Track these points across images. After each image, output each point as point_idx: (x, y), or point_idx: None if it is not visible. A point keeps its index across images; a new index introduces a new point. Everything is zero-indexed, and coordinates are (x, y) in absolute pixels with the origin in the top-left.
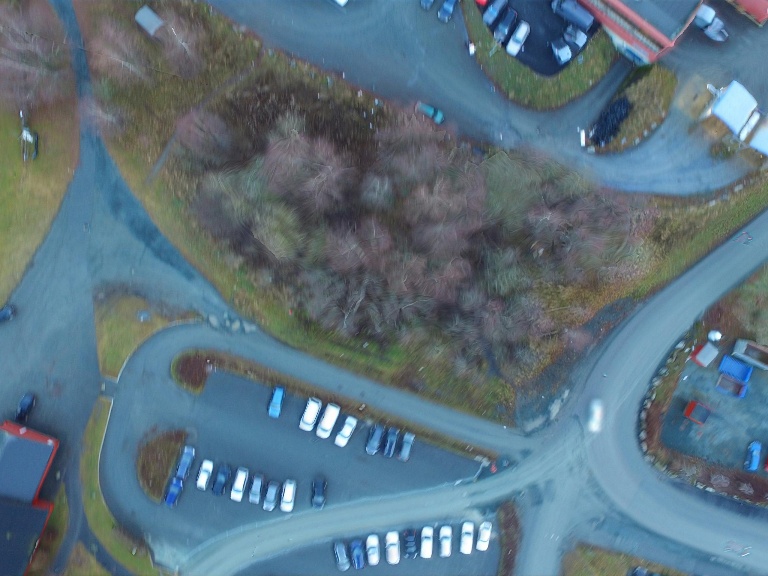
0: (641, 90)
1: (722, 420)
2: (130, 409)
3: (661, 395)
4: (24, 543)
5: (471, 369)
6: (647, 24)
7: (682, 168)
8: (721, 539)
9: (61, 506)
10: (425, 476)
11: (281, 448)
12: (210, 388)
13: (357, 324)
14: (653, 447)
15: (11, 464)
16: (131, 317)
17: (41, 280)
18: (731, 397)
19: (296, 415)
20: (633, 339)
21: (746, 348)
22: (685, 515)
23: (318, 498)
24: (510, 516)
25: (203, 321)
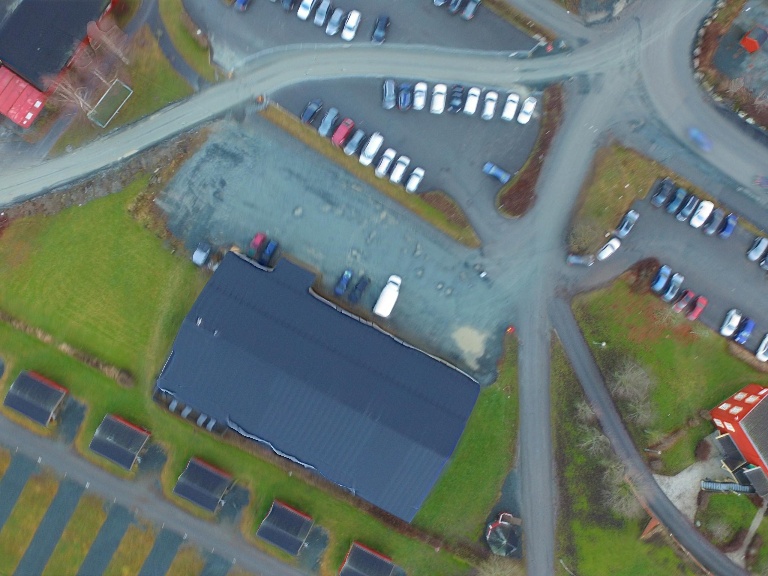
0: None
1: None
2: None
3: (722, 17)
4: None
5: None
6: None
7: None
8: (751, 170)
9: None
10: (483, 41)
11: None
12: None
13: None
14: (705, 65)
15: None
16: None
17: None
18: None
19: None
20: None
21: None
22: (721, 140)
23: (379, 32)
24: (555, 98)
25: None
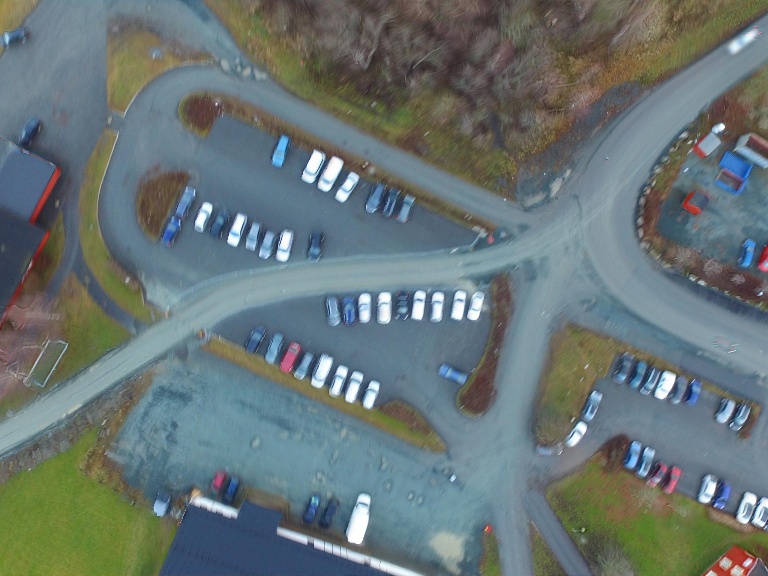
0: None
1: (719, 216)
2: (134, 145)
3: (661, 183)
4: (18, 260)
5: (476, 137)
6: None
7: None
8: (709, 333)
9: (57, 235)
10: (422, 241)
11: (281, 199)
12: (216, 132)
13: (367, 82)
14: (649, 234)
15: (12, 176)
16: (143, 53)
17: (57, 7)
18: (729, 193)
19: (299, 167)
20: (638, 125)
21: (748, 140)
22: (676, 306)
23: (314, 250)
24: (503, 289)
25: (214, 64)
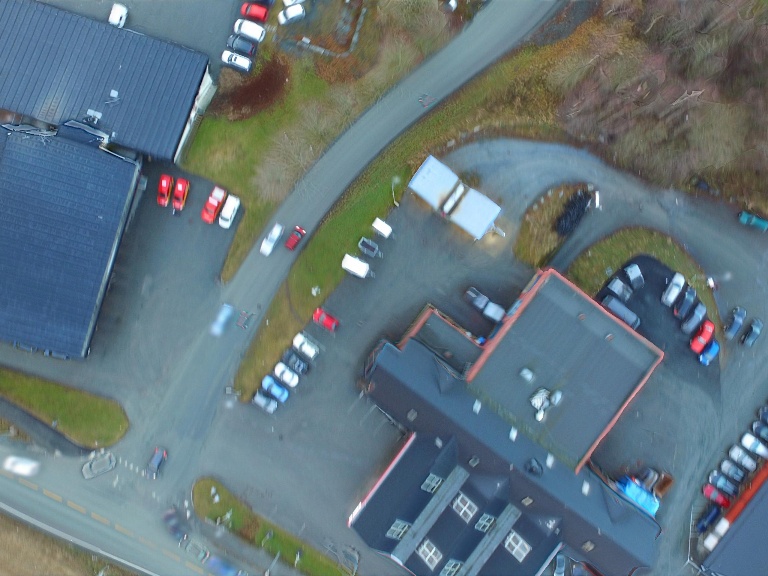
0: (547, 243)
1: None
2: None
3: None
4: None
5: None
6: (577, 290)
7: (507, 165)
8: None
9: None
10: None
11: None
12: None
13: None
14: None
15: None
16: None
17: None
18: None
19: None
20: (535, 5)
21: None
22: None
23: None
24: None
25: None
